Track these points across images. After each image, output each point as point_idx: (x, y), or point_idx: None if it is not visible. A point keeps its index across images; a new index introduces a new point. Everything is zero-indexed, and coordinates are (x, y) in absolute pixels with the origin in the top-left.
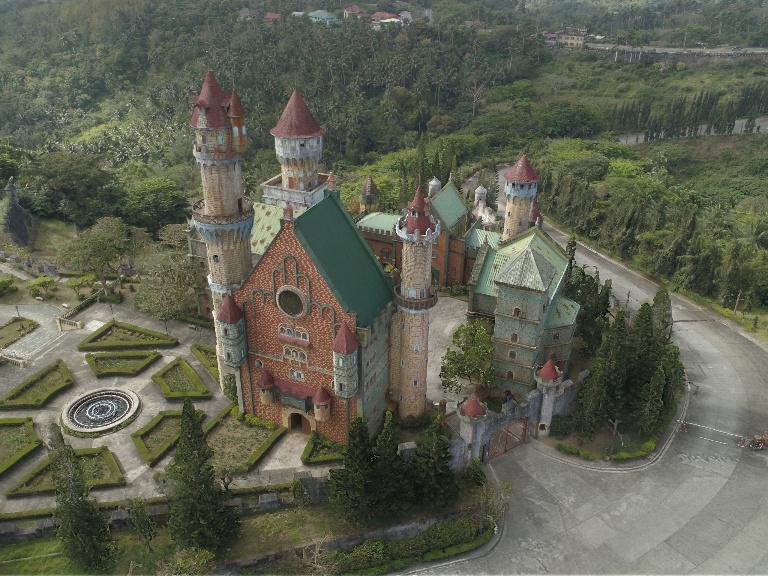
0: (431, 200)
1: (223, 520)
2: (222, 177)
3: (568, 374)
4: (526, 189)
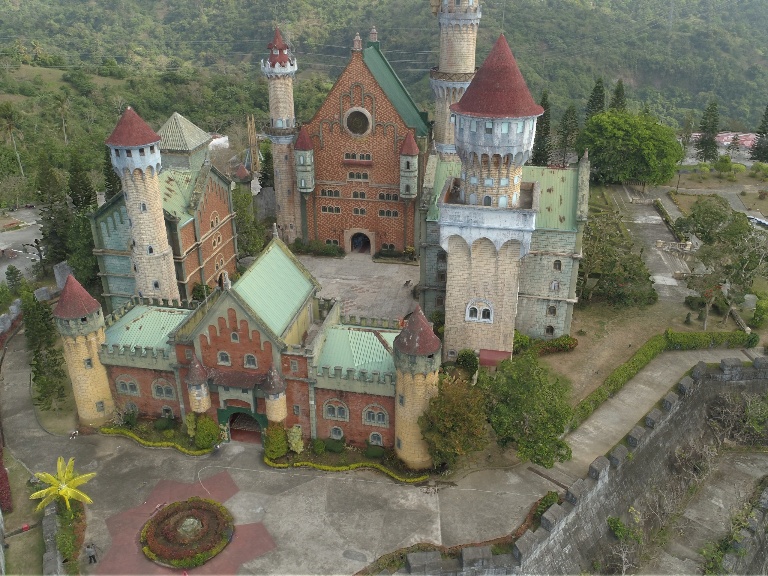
0: (272, 245)
1: None
2: None
3: None
4: None
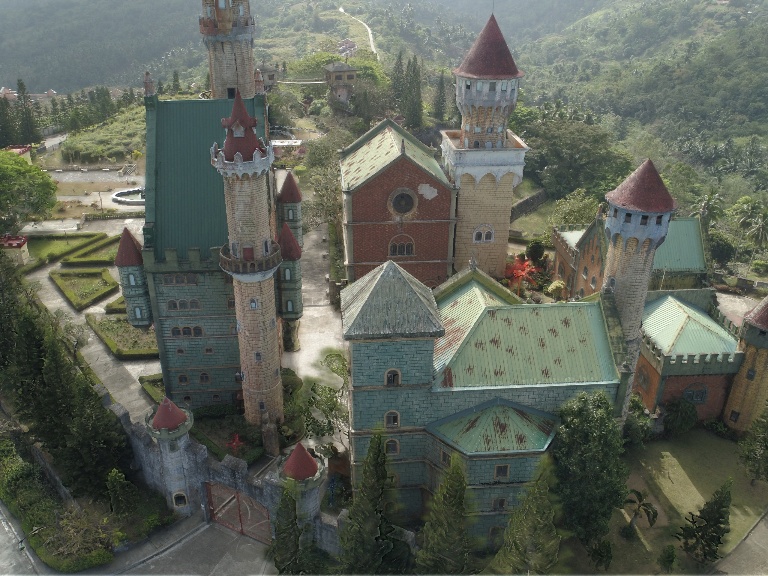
0: None
1: (6, 356)
2: (212, 56)
3: (492, 552)
4: (620, 219)
